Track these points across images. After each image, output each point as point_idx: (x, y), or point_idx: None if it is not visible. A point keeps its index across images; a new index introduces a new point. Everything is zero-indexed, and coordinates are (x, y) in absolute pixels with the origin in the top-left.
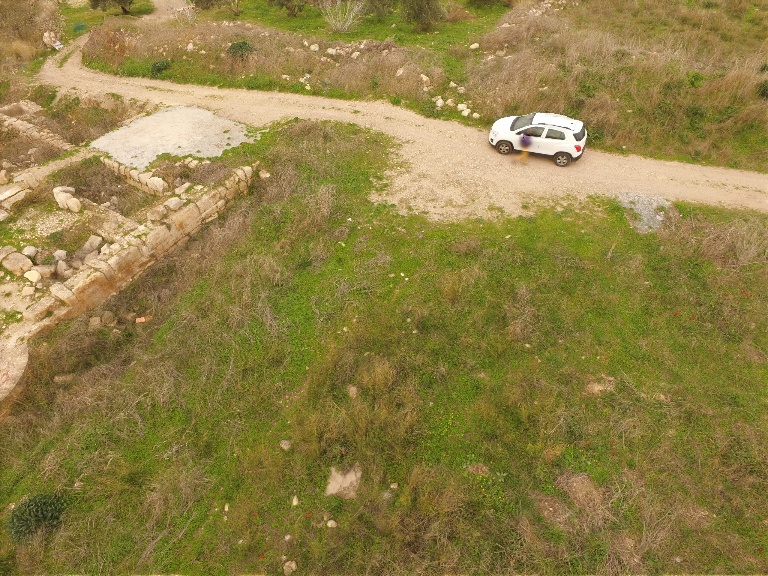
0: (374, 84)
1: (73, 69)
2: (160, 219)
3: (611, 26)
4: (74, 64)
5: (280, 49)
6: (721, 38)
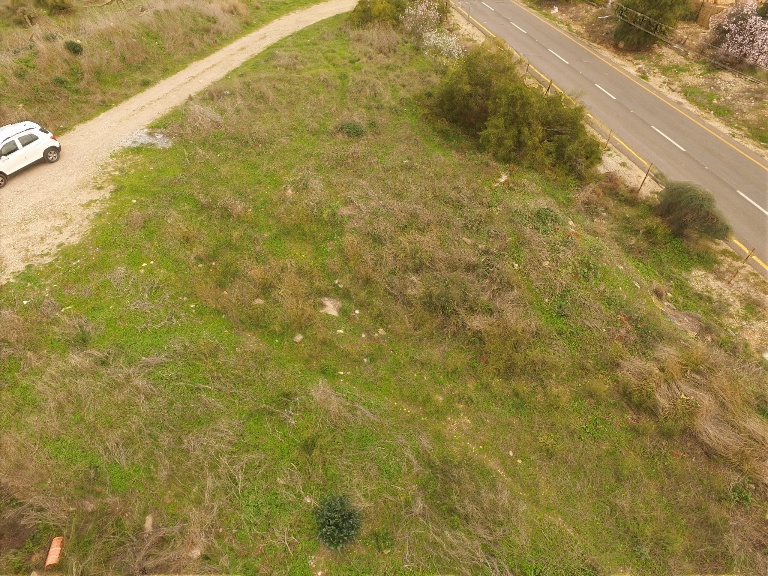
0: None
1: None
2: None
3: None
4: None
5: None
6: None
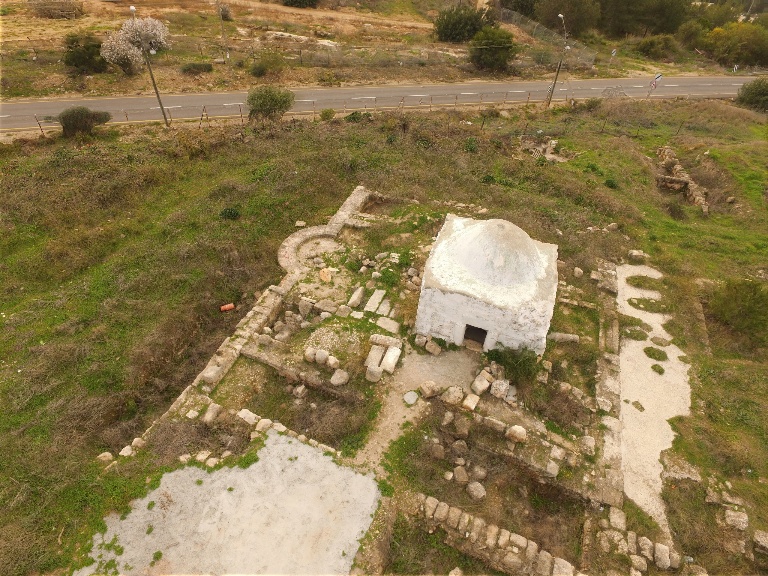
0: None
1: None
2: None
3: None
4: None
5: None
6: None
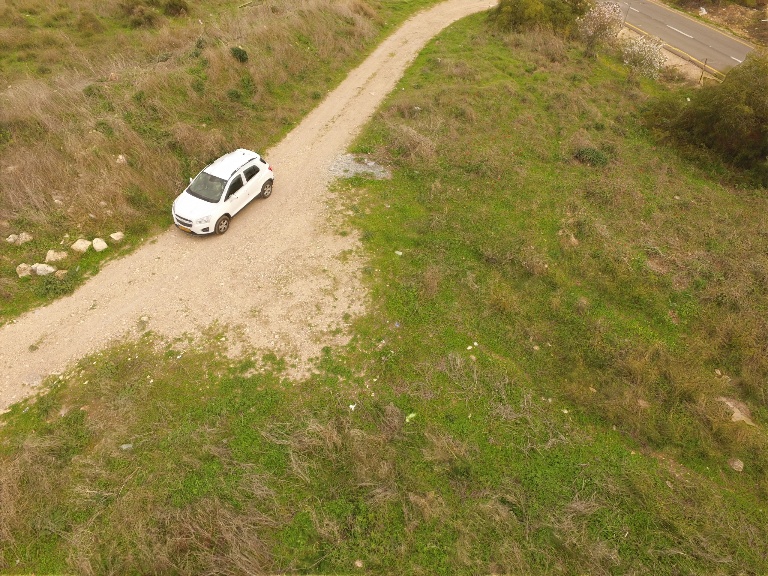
0: None
1: None
2: None
3: None
4: None
5: None
6: (77, 46)
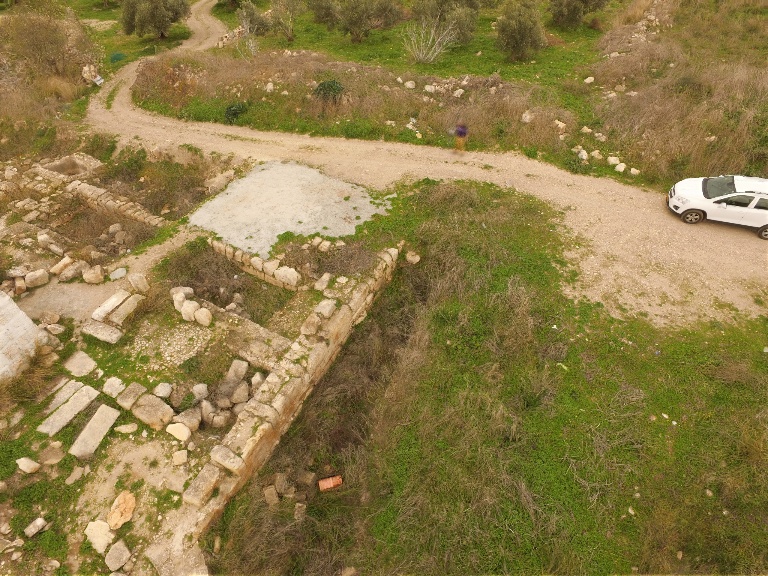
0: (500, 132)
1: (125, 110)
2: (315, 332)
3: (724, 53)
4: (123, 104)
5: (372, 87)
6: None
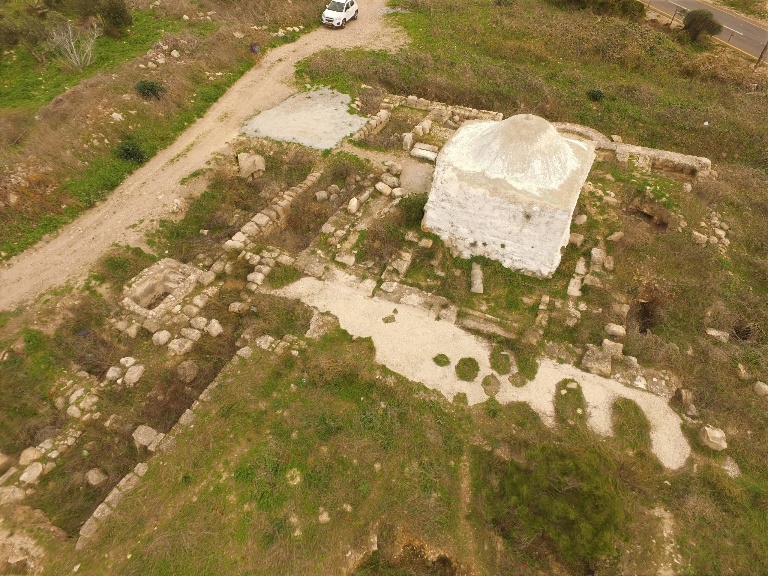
0: None
1: (6, 274)
2: None
3: None
4: None
5: None
6: None
